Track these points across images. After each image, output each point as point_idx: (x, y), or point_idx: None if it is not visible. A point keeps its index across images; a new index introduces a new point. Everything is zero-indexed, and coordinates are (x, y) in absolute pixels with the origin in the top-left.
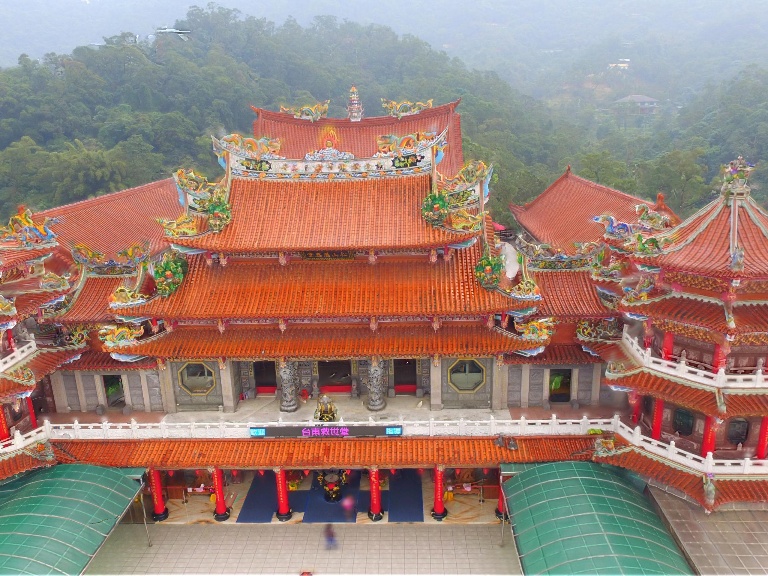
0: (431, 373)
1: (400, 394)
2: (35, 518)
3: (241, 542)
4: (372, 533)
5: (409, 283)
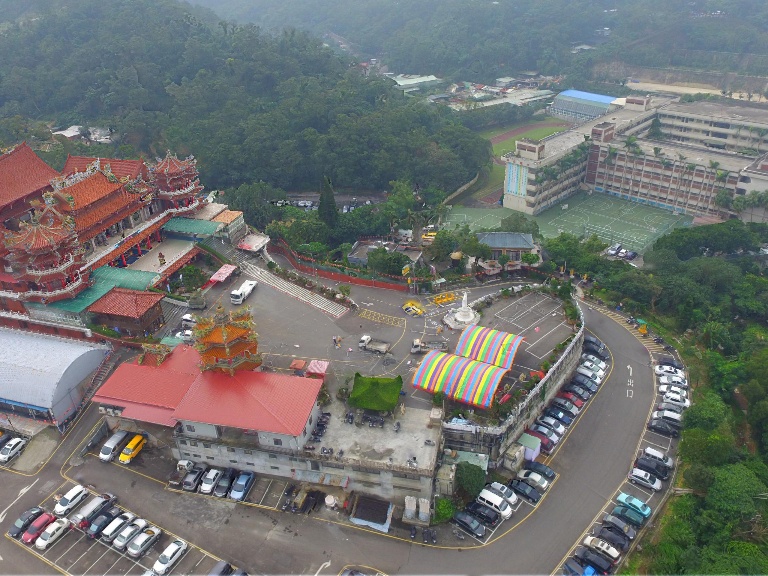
0: None
1: None
2: None
3: None
4: None
5: None
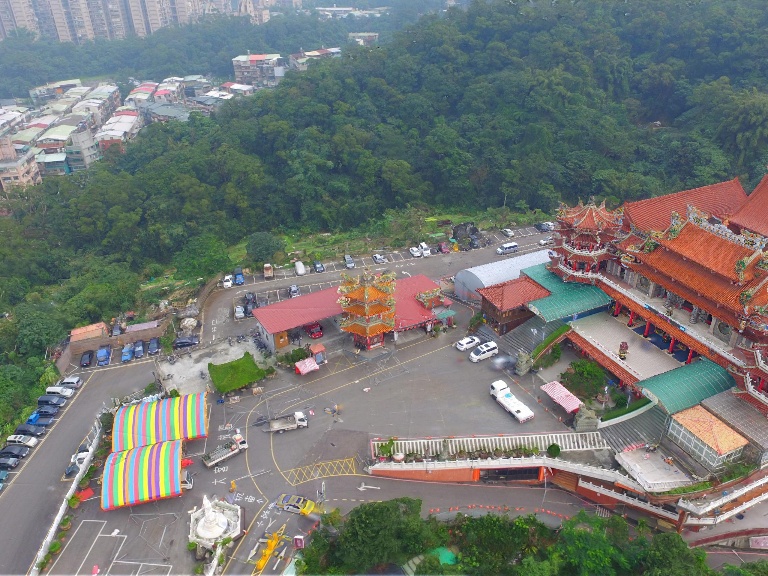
0: (712, 320)
1: (708, 324)
2: (581, 295)
3: (628, 334)
4: (663, 355)
5: (719, 287)
